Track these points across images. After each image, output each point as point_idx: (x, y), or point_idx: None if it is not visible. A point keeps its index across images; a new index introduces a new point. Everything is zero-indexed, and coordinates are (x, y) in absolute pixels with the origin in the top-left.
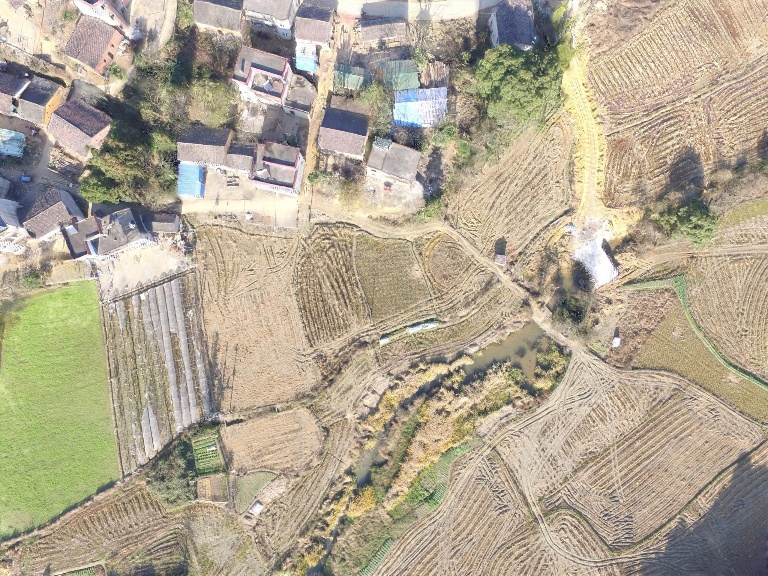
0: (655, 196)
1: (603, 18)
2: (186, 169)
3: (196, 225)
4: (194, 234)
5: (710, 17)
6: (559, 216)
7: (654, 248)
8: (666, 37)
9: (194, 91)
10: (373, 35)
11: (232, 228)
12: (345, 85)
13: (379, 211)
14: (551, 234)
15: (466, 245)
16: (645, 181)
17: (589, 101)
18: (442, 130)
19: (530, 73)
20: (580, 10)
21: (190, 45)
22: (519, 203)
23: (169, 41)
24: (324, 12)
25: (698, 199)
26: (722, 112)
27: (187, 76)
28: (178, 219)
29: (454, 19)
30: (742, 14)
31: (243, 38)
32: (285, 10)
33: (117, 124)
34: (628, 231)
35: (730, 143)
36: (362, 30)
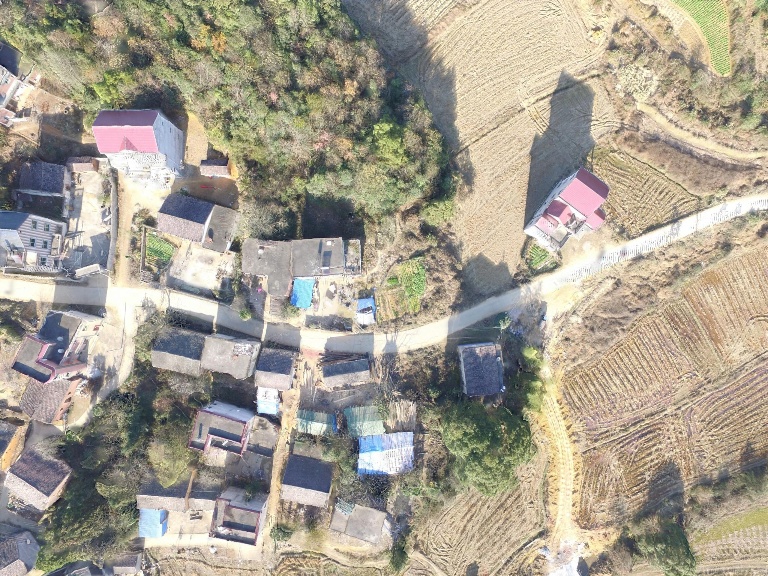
0: (633, 515)
1: (578, 331)
2: (147, 510)
3: (159, 558)
4: (157, 568)
5: (691, 323)
6: (533, 538)
7: (632, 568)
8: (644, 347)
9: (154, 434)
10: (336, 382)
11: (196, 561)
12: (308, 431)
13: (346, 547)
14: (525, 556)
15: (436, 572)
16: (622, 499)
17: (564, 419)
18: (407, 486)
19: (495, 459)
20: (554, 326)
21: (150, 377)
22: (491, 526)
23: (128, 378)
24: (285, 360)
25: (678, 513)
26: (703, 423)
27: (147, 413)
28: (140, 556)
29: (422, 348)
30: (725, 319)
31: (204, 372)
32: (244, 368)
33: (72, 498)
34: (605, 550)
35: (711, 456)
36: (324, 379)
